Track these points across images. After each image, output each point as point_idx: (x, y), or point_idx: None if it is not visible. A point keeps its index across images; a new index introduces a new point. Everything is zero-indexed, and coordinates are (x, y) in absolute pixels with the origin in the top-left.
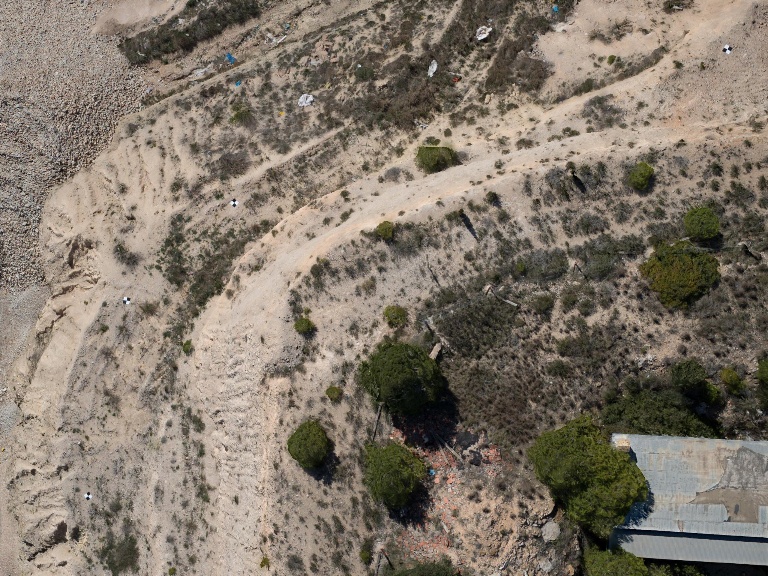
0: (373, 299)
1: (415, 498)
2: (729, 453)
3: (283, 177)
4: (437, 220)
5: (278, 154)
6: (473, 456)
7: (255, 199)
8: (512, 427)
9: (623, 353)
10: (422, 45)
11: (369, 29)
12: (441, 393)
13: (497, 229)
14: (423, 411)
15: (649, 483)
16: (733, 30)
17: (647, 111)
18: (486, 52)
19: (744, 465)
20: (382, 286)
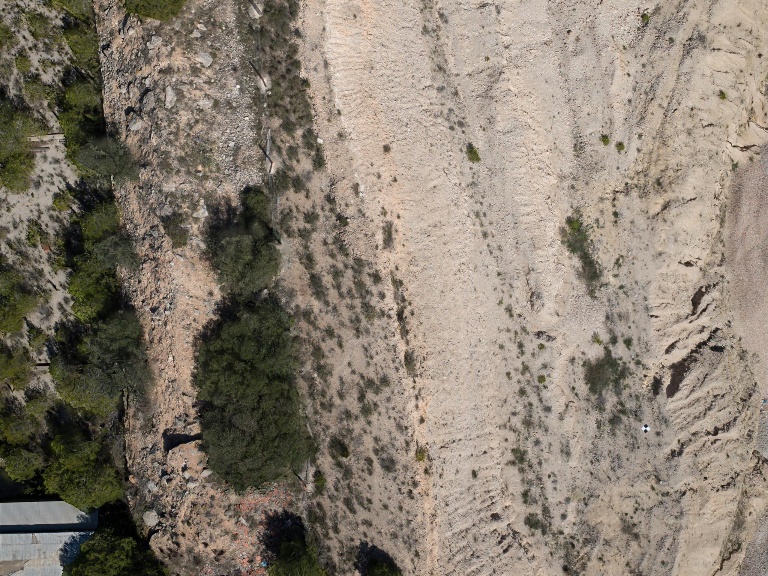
0: None
1: (278, 538)
2: None
3: None
4: None
5: None
6: None
7: None
8: None
9: None
10: None
11: None
12: None
13: None
14: None
15: None
16: None
17: None
18: None
19: None
20: None
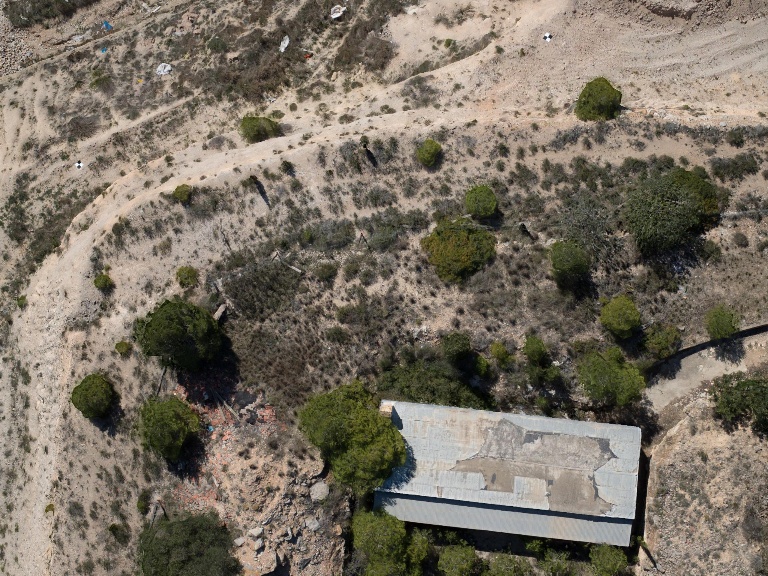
0: (168, 259)
1: (193, 453)
2: (490, 424)
3: (129, 142)
4: (233, 186)
5: (127, 119)
6: (250, 415)
7: (99, 162)
8: (288, 389)
9: (399, 323)
10: (275, 20)
11: (233, 3)
12: (224, 353)
13: (289, 197)
14: (206, 369)
15: (413, 449)
16: (554, 19)
17: (462, 93)
18: (339, 31)
19: (504, 436)
20: (177, 247)
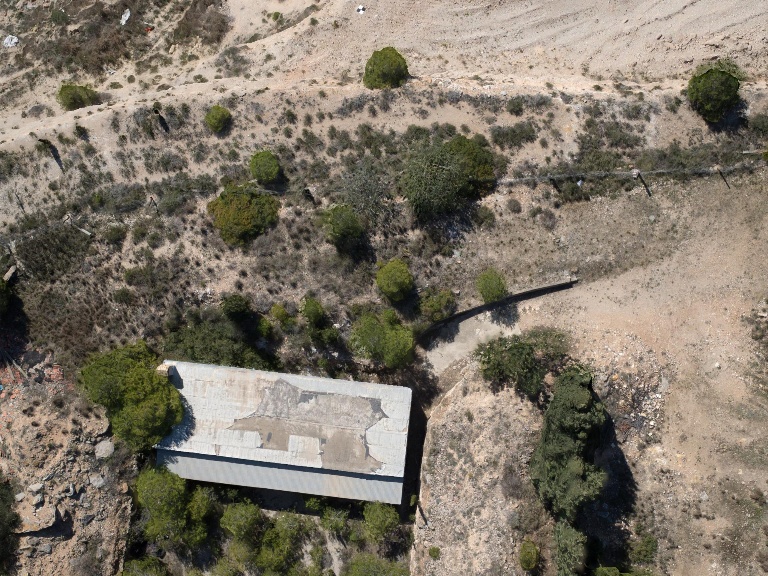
0: None
1: None
2: (267, 384)
3: None
4: (29, 150)
5: None
6: (38, 374)
7: None
8: (75, 349)
9: (184, 285)
10: None
11: None
12: (16, 313)
13: (83, 162)
14: None
15: (192, 408)
16: None
17: (273, 63)
18: (180, 4)
19: (280, 396)
20: None
